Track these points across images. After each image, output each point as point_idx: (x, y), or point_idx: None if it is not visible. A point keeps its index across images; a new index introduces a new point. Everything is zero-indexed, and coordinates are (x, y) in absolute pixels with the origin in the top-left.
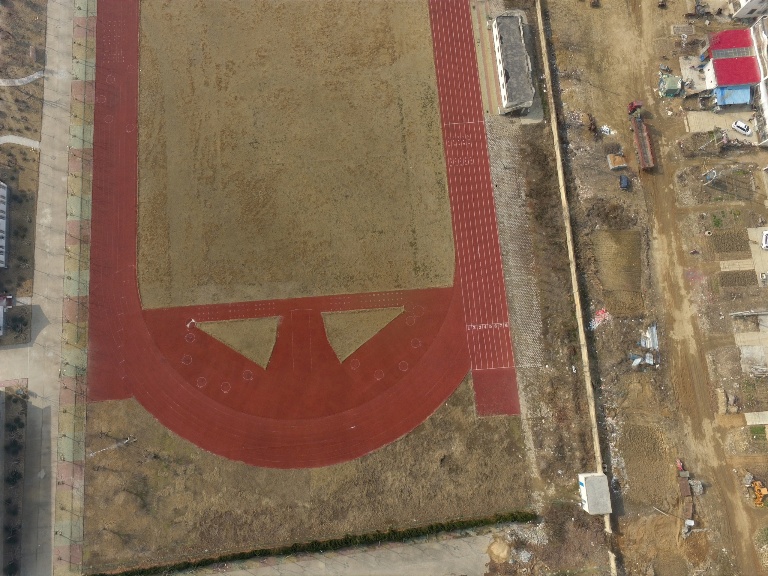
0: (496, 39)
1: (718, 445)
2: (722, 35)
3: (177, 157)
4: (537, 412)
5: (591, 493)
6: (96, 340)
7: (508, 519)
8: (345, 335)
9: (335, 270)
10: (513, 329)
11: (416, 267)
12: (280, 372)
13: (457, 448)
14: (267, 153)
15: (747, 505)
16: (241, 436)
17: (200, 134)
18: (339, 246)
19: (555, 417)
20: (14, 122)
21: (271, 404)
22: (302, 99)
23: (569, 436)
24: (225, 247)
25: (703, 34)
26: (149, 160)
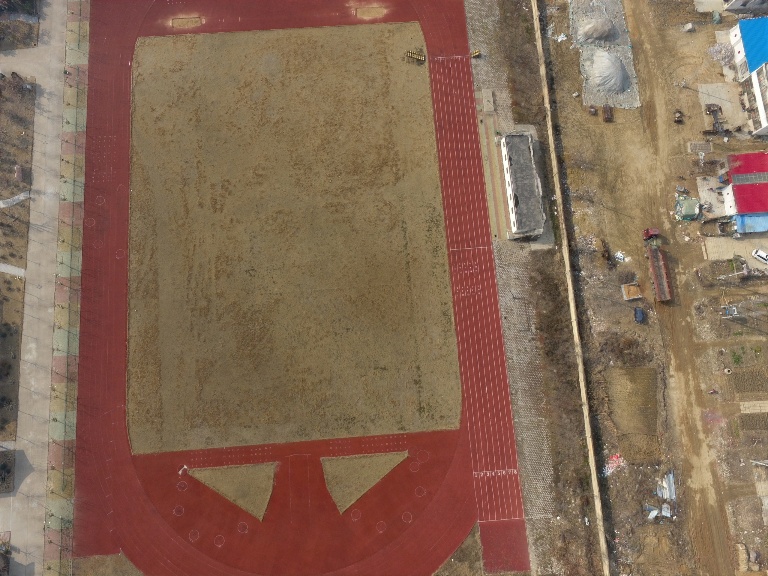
0: (505, 159)
1: None
2: (742, 158)
3: (169, 286)
4: (548, 568)
5: None
6: (83, 489)
7: None
8: (346, 483)
9: (335, 411)
10: (523, 476)
11: (420, 407)
12: (277, 524)
13: None
14: (264, 282)
15: None
16: None
17: (194, 261)
18: (339, 384)
19: (567, 575)
20: None
21: (267, 560)
22: (301, 222)
23: None
24: (219, 385)
25: (721, 152)
26: (140, 289)
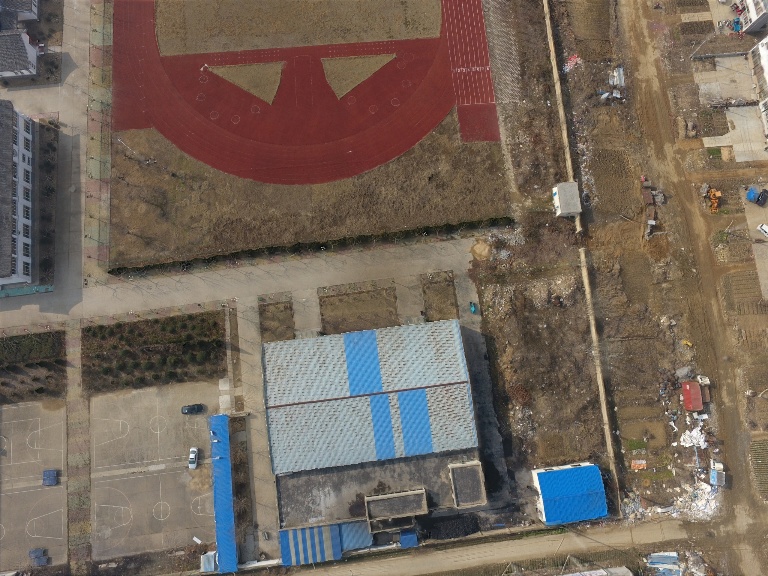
0: None
1: (678, 164)
2: None
3: None
4: (515, 139)
5: (563, 196)
6: (119, 81)
7: (489, 221)
8: (343, 77)
9: (333, 24)
10: (494, 72)
11: (406, 22)
12: (284, 107)
13: (443, 168)
14: None
15: (704, 212)
16: (250, 159)
17: None
18: (337, 4)
19: (531, 142)
20: None
21: (276, 133)
22: None
23: (544, 156)
24: (234, 5)
25: None
26: None
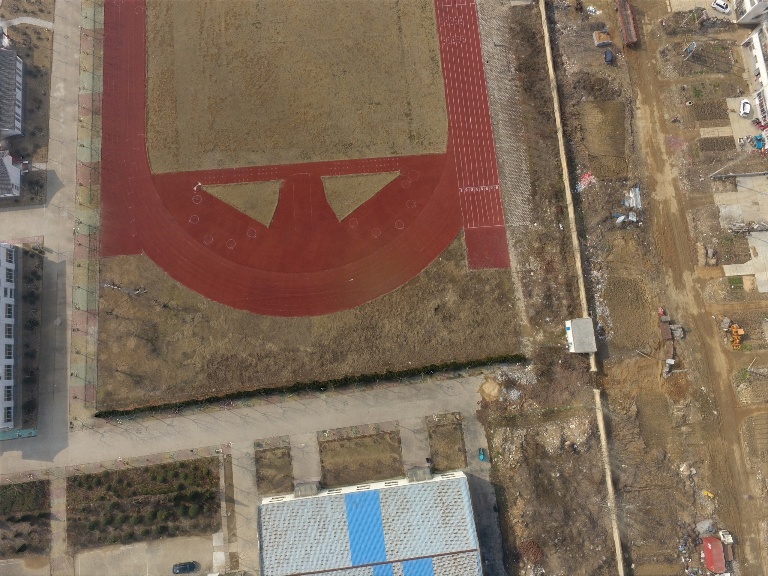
0: None
1: (698, 294)
2: None
3: (183, 36)
4: (526, 266)
5: (577, 333)
6: (108, 201)
7: (498, 359)
8: (344, 197)
9: (334, 138)
10: (503, 191)
11: (411, 135)
12: (282, 230)
13: (450, 298)
14: (269, 32)
15: (725, 348)
16: (246, 288)
17: (205, 15)
18: (338, 116)
19: (543, 270)
20: (28, 5)
21: (274, 259)
22: None
23: (556, 286)
24: (230, 118)
25: None
26: (157, 39)
